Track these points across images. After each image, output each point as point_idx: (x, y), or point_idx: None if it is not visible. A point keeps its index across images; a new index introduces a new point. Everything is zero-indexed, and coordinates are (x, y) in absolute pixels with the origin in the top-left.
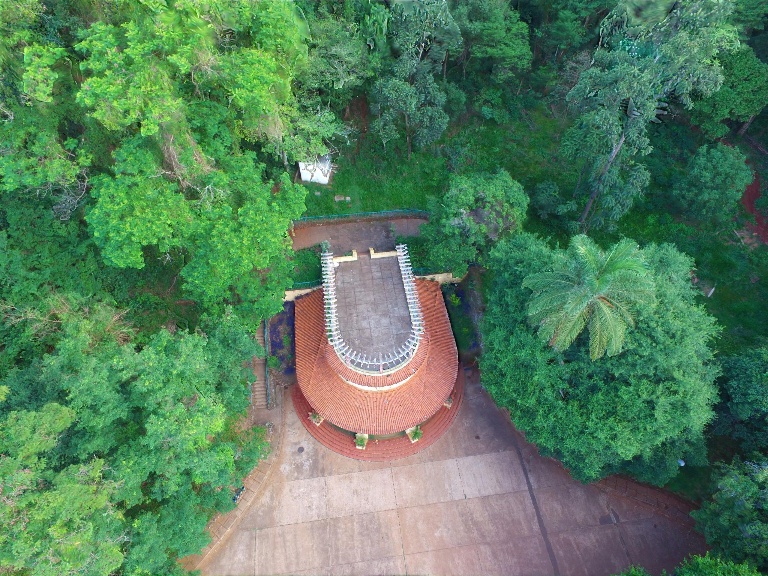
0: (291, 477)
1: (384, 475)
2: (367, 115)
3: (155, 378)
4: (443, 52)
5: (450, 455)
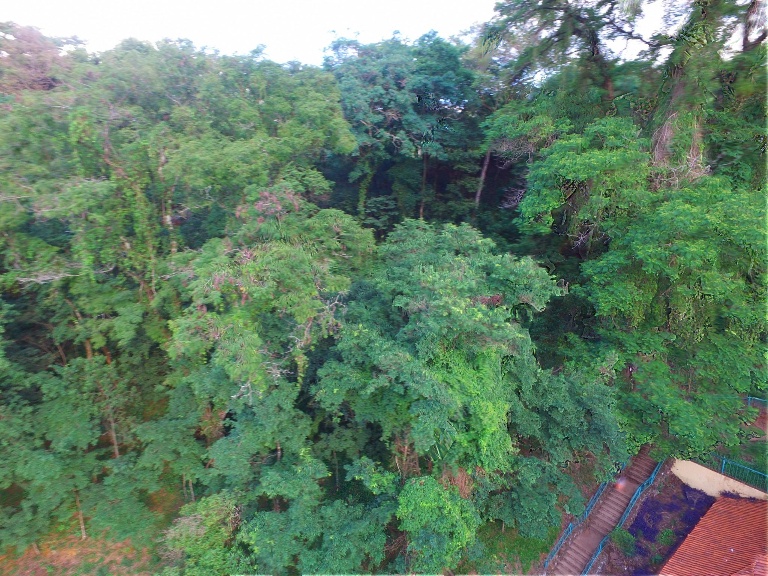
0: None
1: None
2: None
3: (470, 262)
4: None
5: None
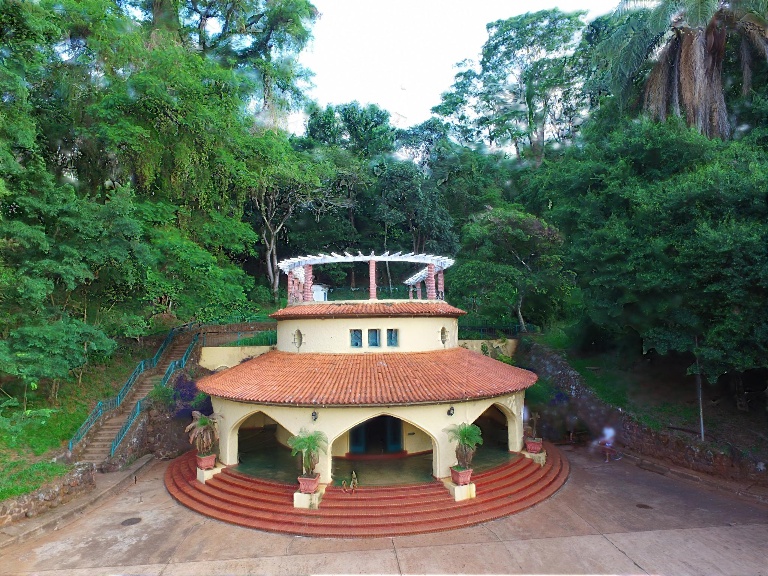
0: (54, 562)
1: (370, 561)
2: (371, 207)
3: None
4: (445, 172)
5: (579, 529)
